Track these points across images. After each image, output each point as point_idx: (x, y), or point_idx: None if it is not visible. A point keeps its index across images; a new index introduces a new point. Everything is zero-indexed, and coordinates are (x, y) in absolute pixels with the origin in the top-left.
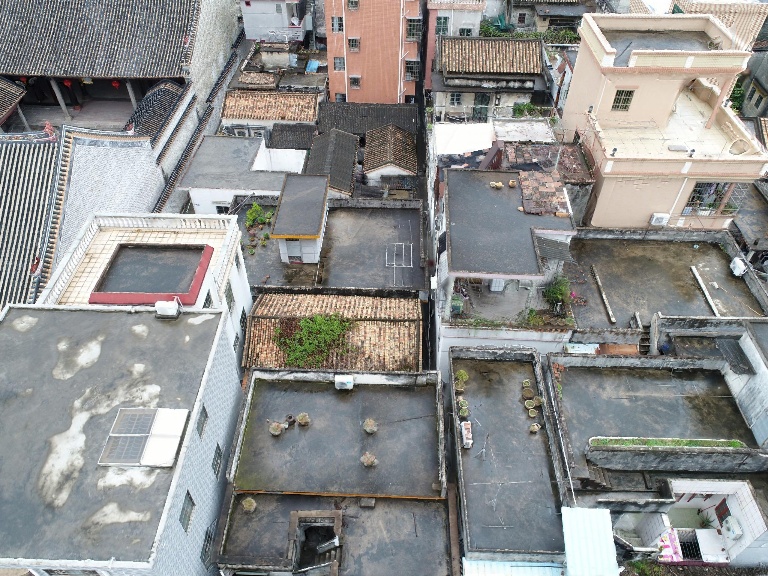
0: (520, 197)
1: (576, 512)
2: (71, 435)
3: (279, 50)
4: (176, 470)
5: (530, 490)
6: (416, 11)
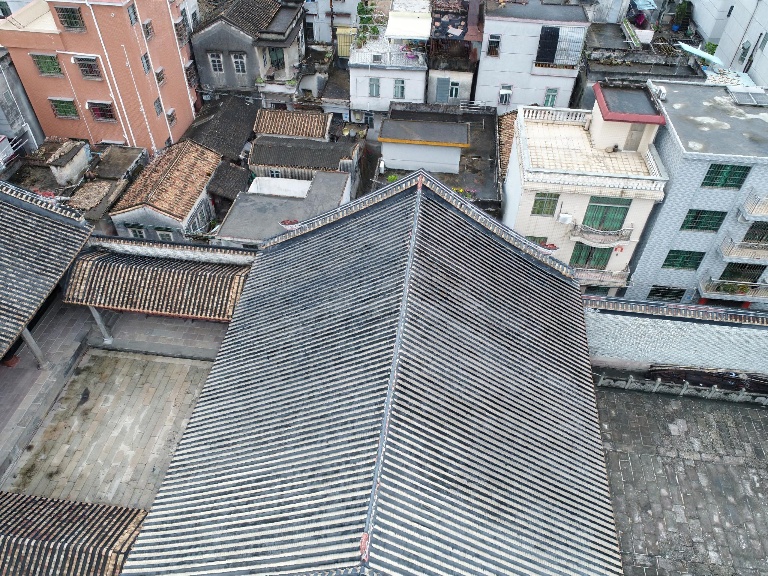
0: (512, 3)
1: (684, 47)
2: (763, 117)
3: (75, 150)
4: (761, 87)
5: (662, 70)
6: (176, 13)
